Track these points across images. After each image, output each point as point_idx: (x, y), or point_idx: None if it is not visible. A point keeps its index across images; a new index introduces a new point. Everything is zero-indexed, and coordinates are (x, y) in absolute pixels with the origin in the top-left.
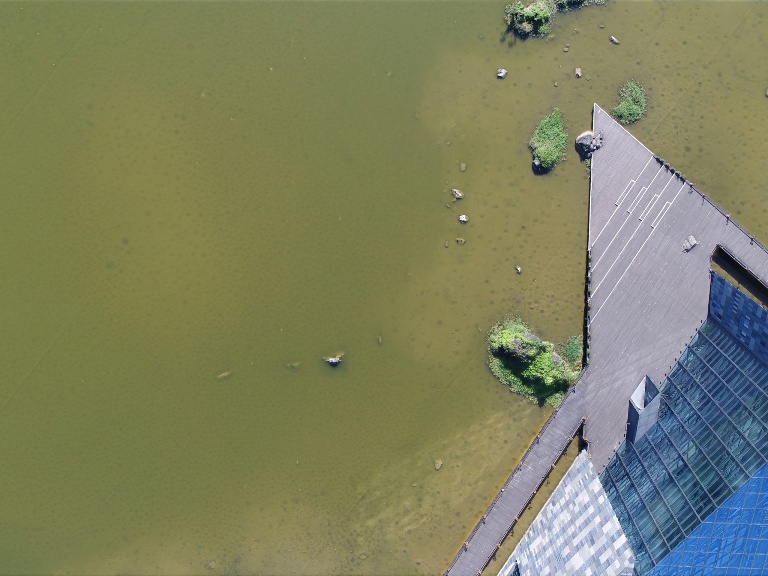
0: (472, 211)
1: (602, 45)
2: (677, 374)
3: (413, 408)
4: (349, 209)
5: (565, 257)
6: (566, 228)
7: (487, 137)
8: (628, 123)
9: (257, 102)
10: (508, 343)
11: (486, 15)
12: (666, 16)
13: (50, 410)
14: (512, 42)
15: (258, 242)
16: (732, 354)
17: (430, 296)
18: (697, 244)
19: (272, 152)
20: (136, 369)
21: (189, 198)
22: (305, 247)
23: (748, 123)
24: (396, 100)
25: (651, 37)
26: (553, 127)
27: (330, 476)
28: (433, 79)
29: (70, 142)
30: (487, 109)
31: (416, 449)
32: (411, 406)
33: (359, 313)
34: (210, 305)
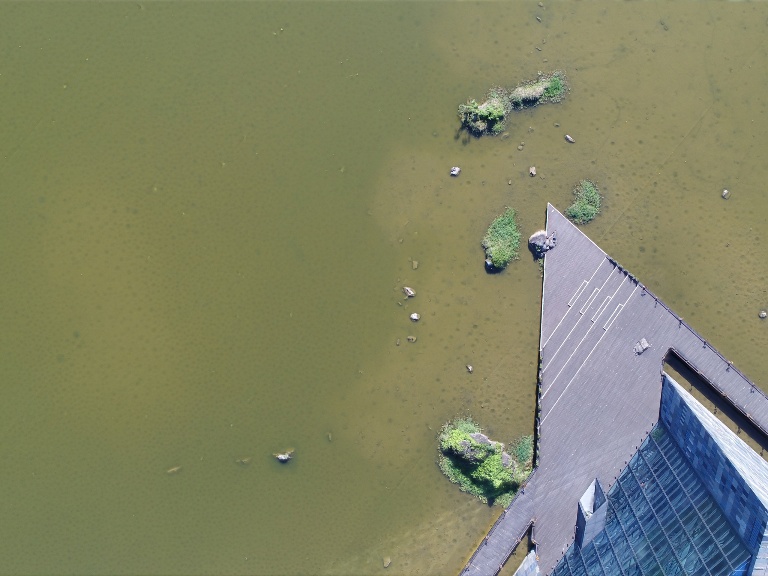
0: (424, 309)
1: (557, 143)
2: (627, 478)
3: (362, 505)
4: (300, 305)
5: (517, 356)
6: (518, 327)
7: (440, 235)
8: (582, 223)
9: (209, 197)
10: (457, 445)
11: (440, 112)
12: (622, 115)
13: (0, 502)
14: (466, 139)
15: (209, 337)
16: (677, 468)
17: (381, 394)
18: (649, 347)
19: (224, 247)
20: (86, 463)
21: (140, 292)
22: (256, 343)
23: (703, 224)
24: (349, 196)
25: (607, 136)
26: (506, 226)
27: (279, 572)
28: (386, 176)
29: (22, 235)
30: (440, 207)
31: (365, 546)
32: (360, 503)
33: (309, 410)
34: (160, 400)
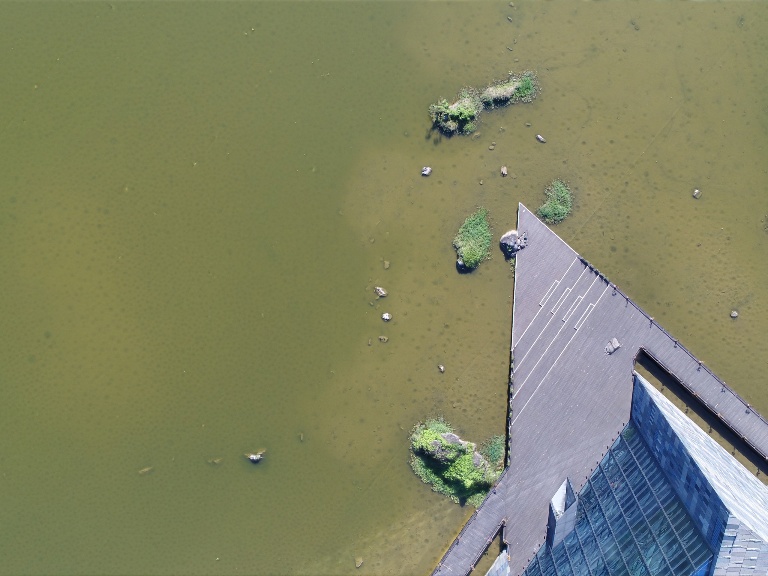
0: (395, 309)
1: (528, 143)
2: (598, 477)
3: (334, 506)
4: (272, 305)
5: (488, 356)
6: (490, 327)
7: (411, 235)
8: (553, 222)
9: (180, 197)
10: (428, 445)
11: (412, 112)
12: (593, 115)
13: None
14: (437, 139)
15: (180, 338)
16: (646, 468)
17: (352, 394)
18: (620, 347)
19: (195, 247)
20: (57, 463)
21: (112, 293)
22: (227, 343)
23: (675, 224)
24: (320, 196)
25: (578, 136)
26: (477, 226)
27: (250, 572)
28: (357, 176)
29: None
30: (411, 207)
31: (337, 547)
32: (332, 503)
33: (281, 410)
34: (132, 400)
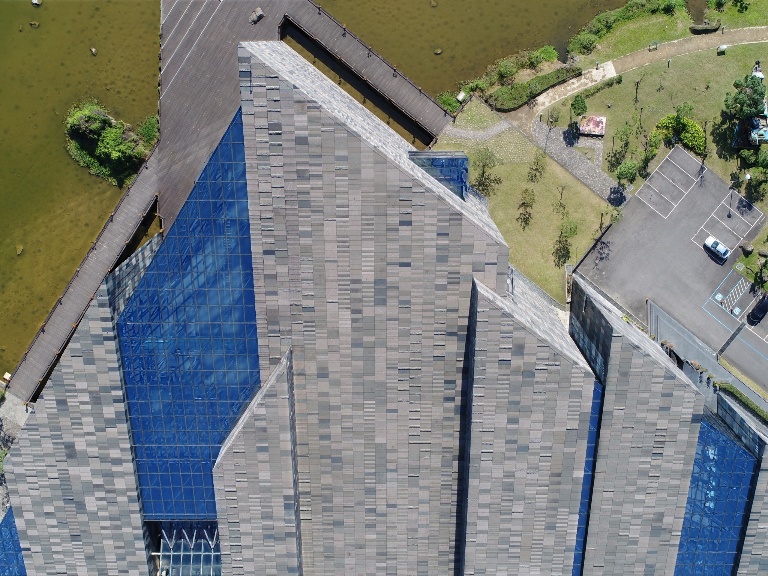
0: None
1: None
2: None
3: None
4: None
5: (140, 37)
6: (140, 8)
7: None
8: None
9: None
10: (74, 119)
11: None
12: None
13: None
14: None
15: None
16: None
17: (6, 81)
18: (264, 16)
19: None
20: None
21: None
22: None
23: None
24: None
25: None
26: None
27: None
28: None
29: None
30: None
31: None
32: None
33: None
34: None
